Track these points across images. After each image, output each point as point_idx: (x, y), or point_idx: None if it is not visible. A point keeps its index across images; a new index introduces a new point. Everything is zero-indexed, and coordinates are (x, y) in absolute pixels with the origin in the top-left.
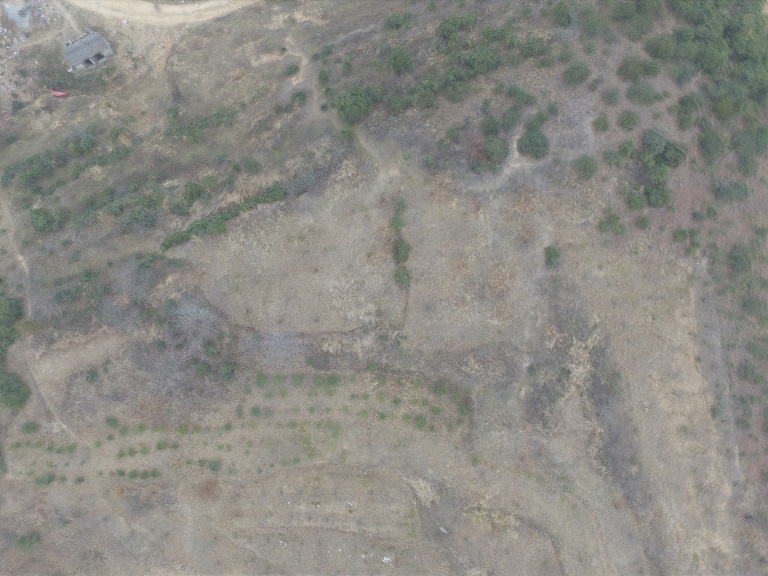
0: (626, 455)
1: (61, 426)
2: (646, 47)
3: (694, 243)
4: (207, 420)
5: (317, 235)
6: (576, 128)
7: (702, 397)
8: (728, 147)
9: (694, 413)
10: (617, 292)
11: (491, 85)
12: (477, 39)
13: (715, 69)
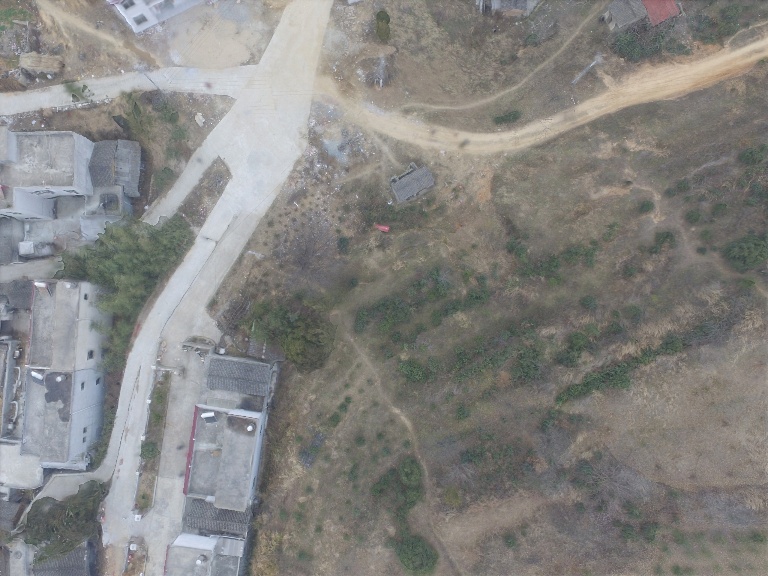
0: None
1: None
2: None
3: None
4: None
5: (722, 386)
6: None
7: None
8: None
9: None
10: None
11: None
12: None
13: None
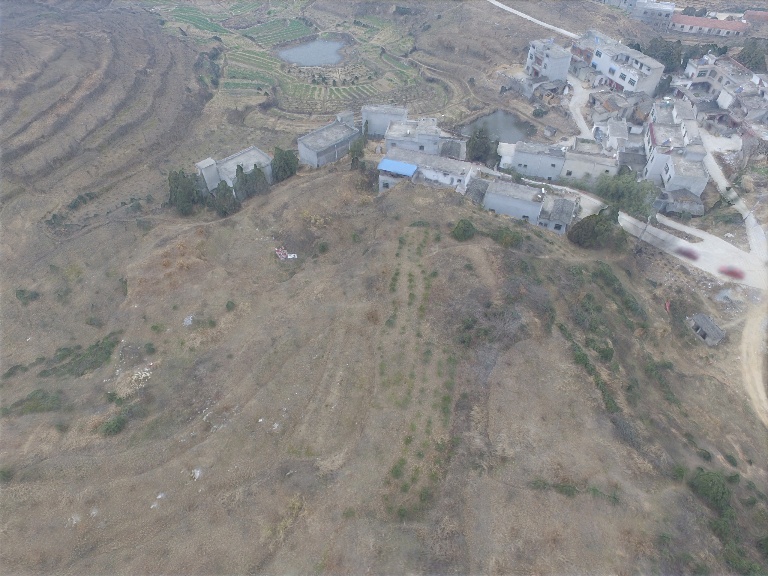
0: None
1: (435, 251)
2: None
3: None
4: (425, 324)
5: (577, 428)
6: None
7: None
8: None
9: None
10: None
11: None
12: None
13: None
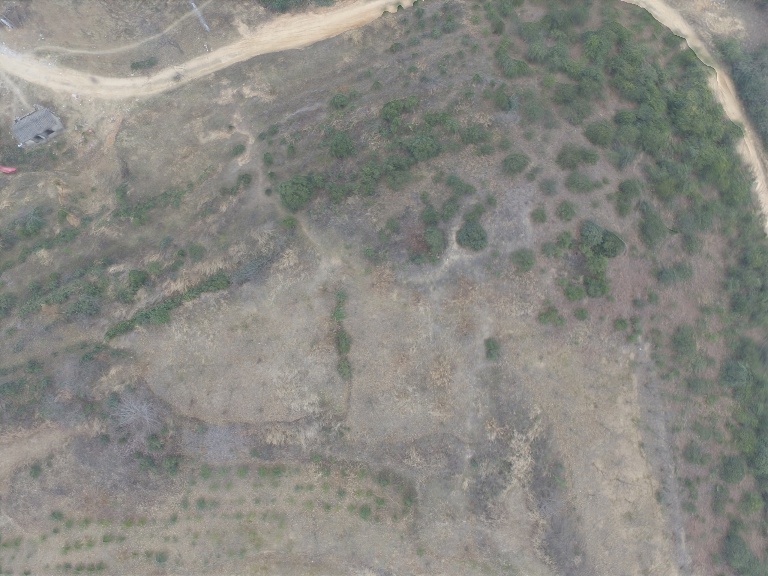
0: (569, 544)
1: (7, 519)
2: (587, 132)
3: (635, 330)
4: (153, 511)
5: (260, 324)
6: (515, 219)
7: (647, 481)
8: (670, 231)
9: (638, 498)
10: (558, 382)
11: (432, 173)
12: (419, 123)
13: (657, 151)
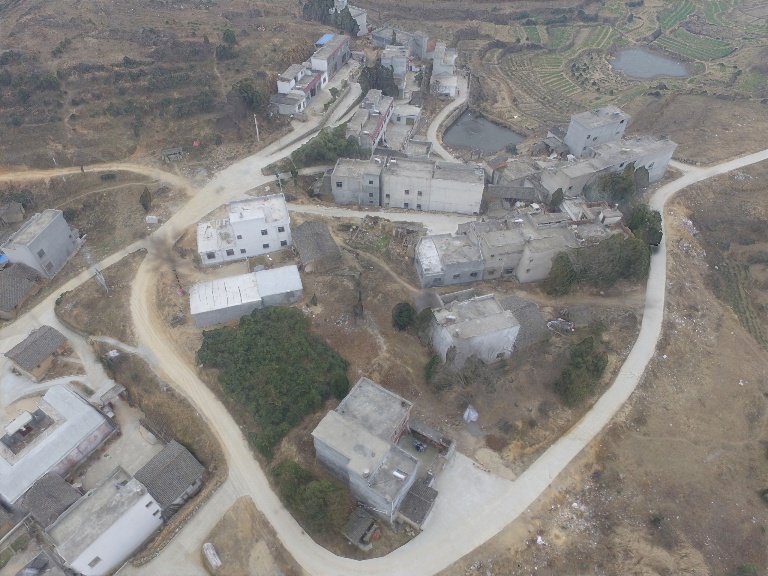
0: None
1: None
2: None
3: None
4: None
5: None
6: None
7: None
8: None
9: None
10: None
11: None
12: None
13: None
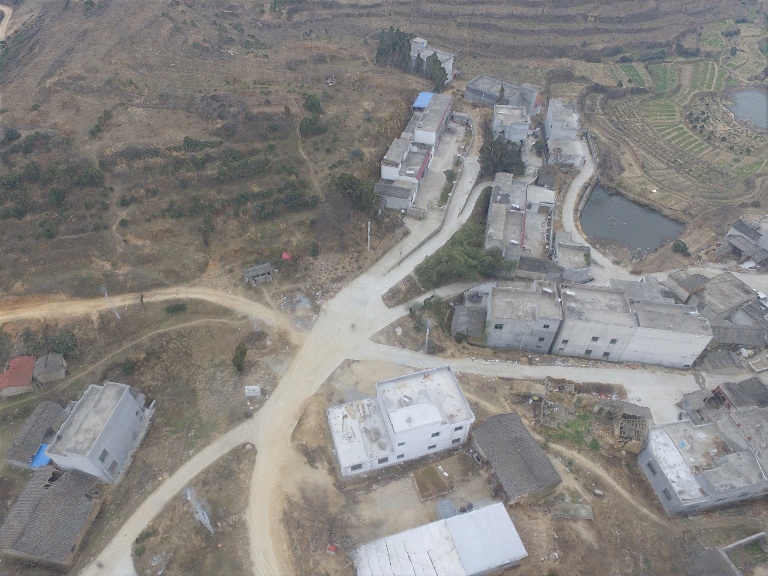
0: None
1: None
2: None
3: None
4: None
5: None
6: None
7: None
8: None
9: None
10: None
11: (14, 169)
12: (6, 197)
13: None
